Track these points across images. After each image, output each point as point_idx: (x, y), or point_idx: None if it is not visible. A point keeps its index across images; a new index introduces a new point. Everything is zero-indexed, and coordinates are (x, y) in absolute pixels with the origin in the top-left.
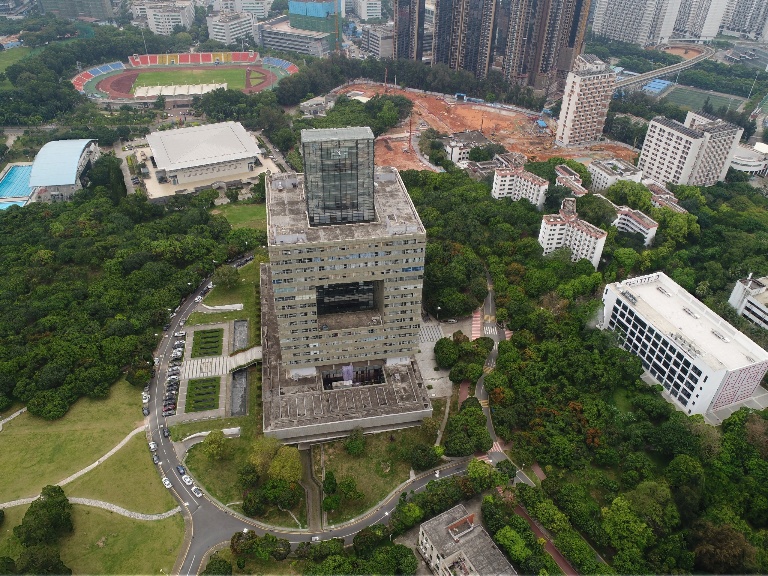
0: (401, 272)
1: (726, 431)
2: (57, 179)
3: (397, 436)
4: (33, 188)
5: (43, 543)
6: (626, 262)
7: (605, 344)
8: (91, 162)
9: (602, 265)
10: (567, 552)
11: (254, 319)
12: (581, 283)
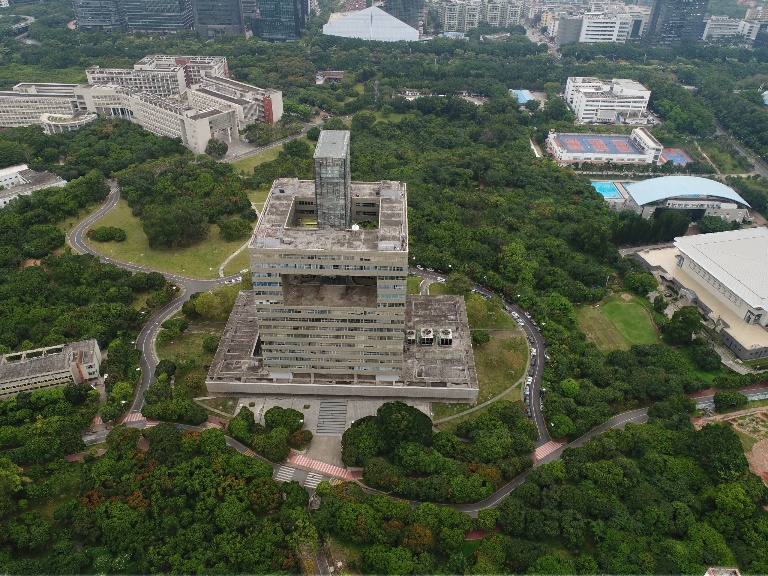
0: None
1: None
2: (640, 195)
3: None
4: None
5: None
6: None
7: None
8: (705, 213)
9: None
10: None
11: None
12: None
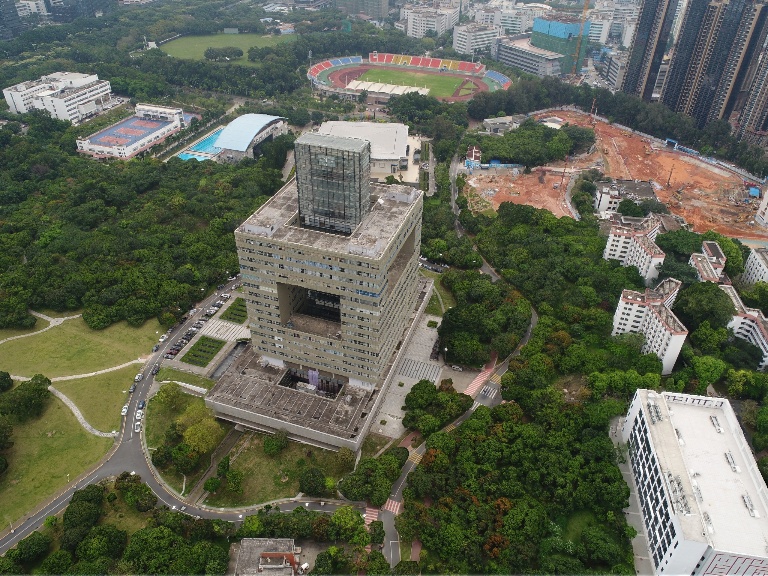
0: (356, 293)
1: None
2: (234, 145)
3: (318, 454)
4: (221, 149)
5: None
6: (702, 374)
7: (600, 455)
8: (273, 137)
9: (679, 369)
10: None
11: None
12: (624, 378)
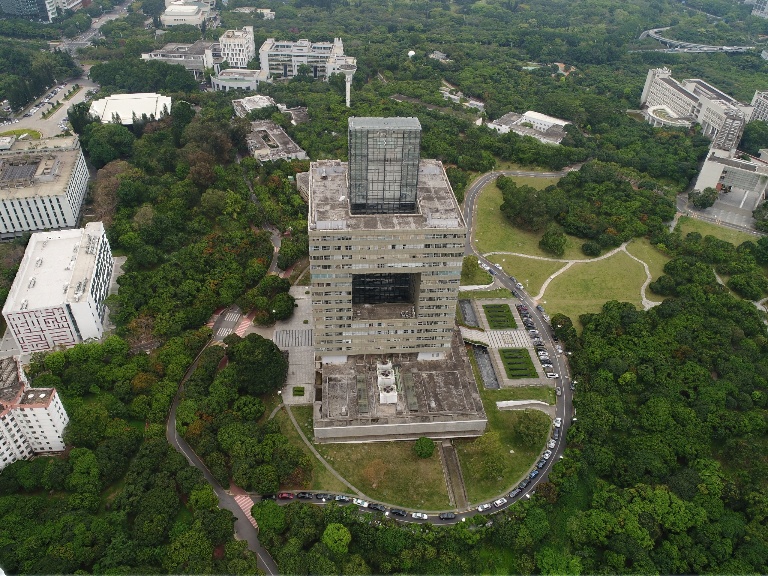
0: None
1: (109, 244)
2: None
3: None
4: None
5: None
6: None
7: None
8: None
9: None
10: None
11: (478, 387)
12: None
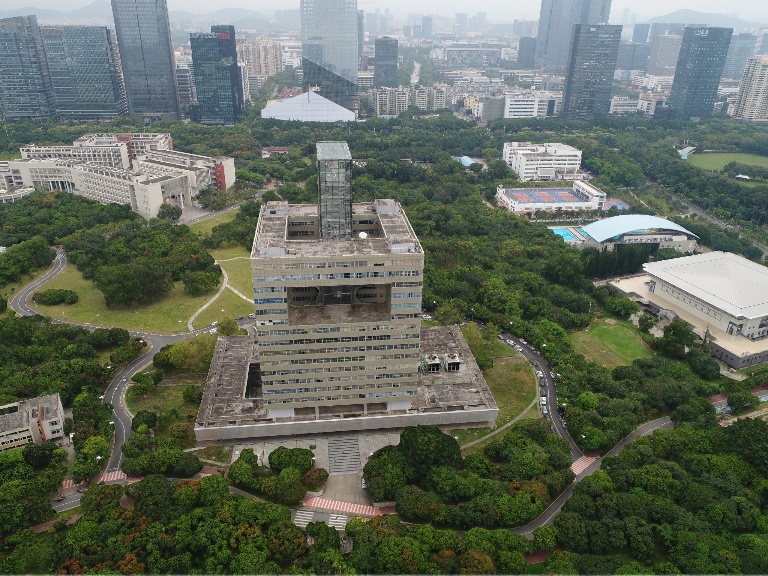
0: None
1: None
2: (598, 233)
3: None
4: None
5: (191, 290)
6: None
7: None
8: (660, 247)
9: None
10: None
11: None
12: None
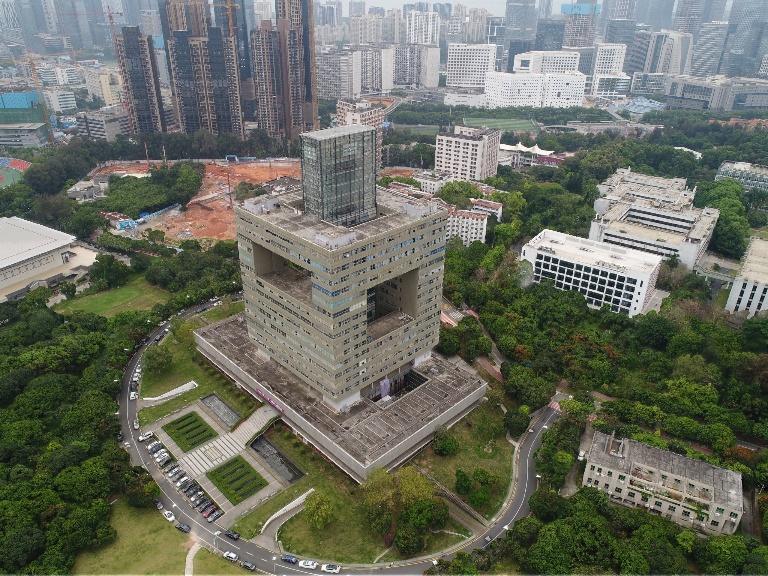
0: (430, 256)
1: None
2: None
3: (468, 422)
4: None
5: None
6: (508, 234)
7: None
8: None
9: None
10: (680, 431)
11: (222, 389)
12: (493, 256)
